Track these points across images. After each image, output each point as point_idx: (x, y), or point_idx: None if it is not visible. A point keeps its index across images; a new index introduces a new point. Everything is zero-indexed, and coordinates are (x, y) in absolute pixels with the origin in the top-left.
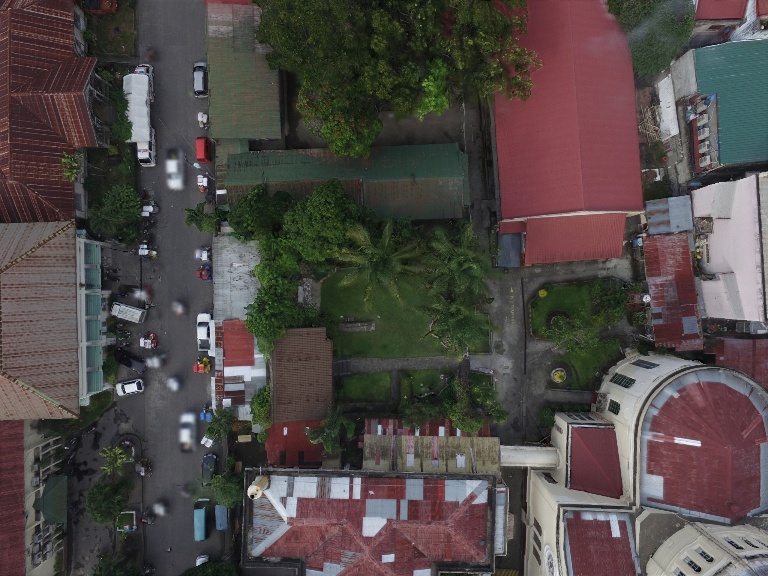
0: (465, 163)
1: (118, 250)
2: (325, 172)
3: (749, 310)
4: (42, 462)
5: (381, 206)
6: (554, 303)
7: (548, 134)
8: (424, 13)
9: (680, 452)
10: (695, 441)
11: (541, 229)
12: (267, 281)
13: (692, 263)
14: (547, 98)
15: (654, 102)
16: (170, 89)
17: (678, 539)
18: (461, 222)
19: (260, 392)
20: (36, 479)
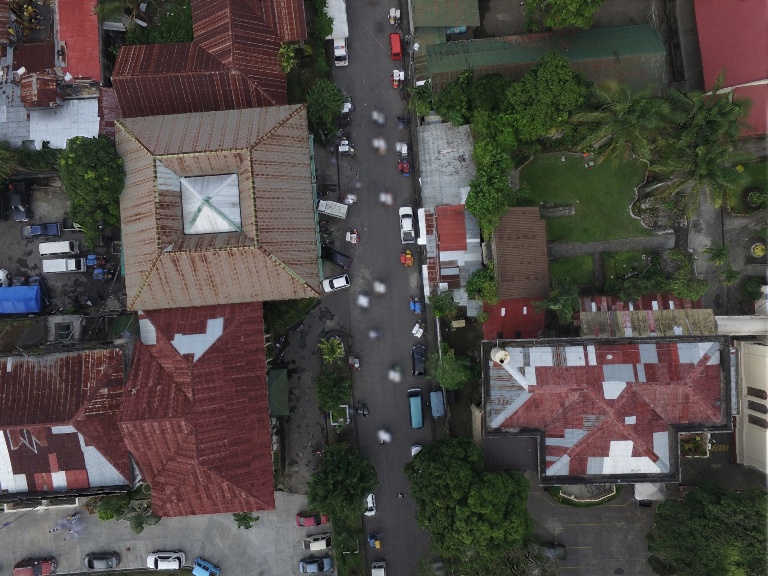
0: None
1: (315, 150)
2: (528, 55)
3: None
4: (266, 354)
5: None
6: (748, 180)
7: (754, 2)
8: None
9: None
10: None
11: (747, 99)
12: (489, 158)
13: None
14: None
15: None
16: None
17: None
18: (658, 102)
19: (479, 273)
20: None
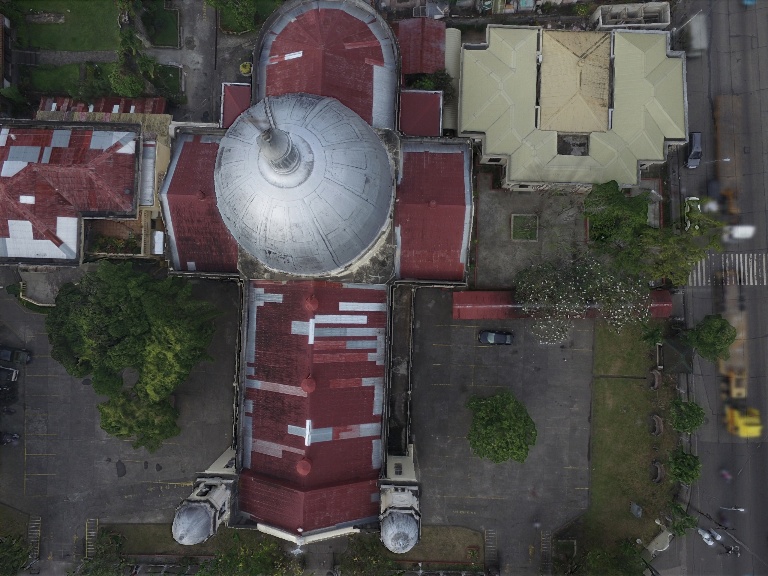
0: None
1: None
2: None
3: None
4: None
5: None
6: None
7: None
8: None
9: (288, 67)
10: (299, 52)
11: None
12: None
13: None
14: None
15: None
16: None
17: None
18: None
19: None
20: None
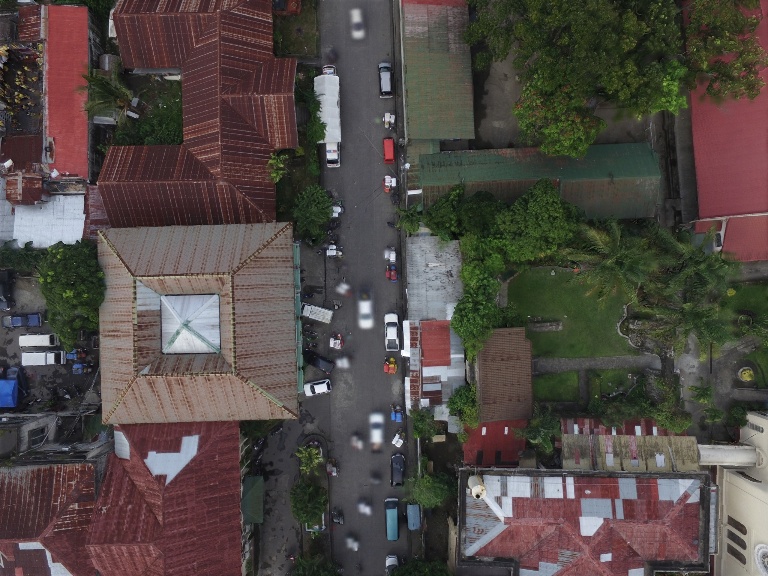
0: None
1: (303, 251)
2: (521, 172)
3: None
4: (242, 462)
5: None
6: (739, 302)
7: (752, 133)
8: (667, 12)
9: None
10: None
11: (741, 228)
12: (476, 281)
13: None
14: None
15: None
16: (353, 90)
17: None
18: (651, 221)
19: (461, 392)
20: None
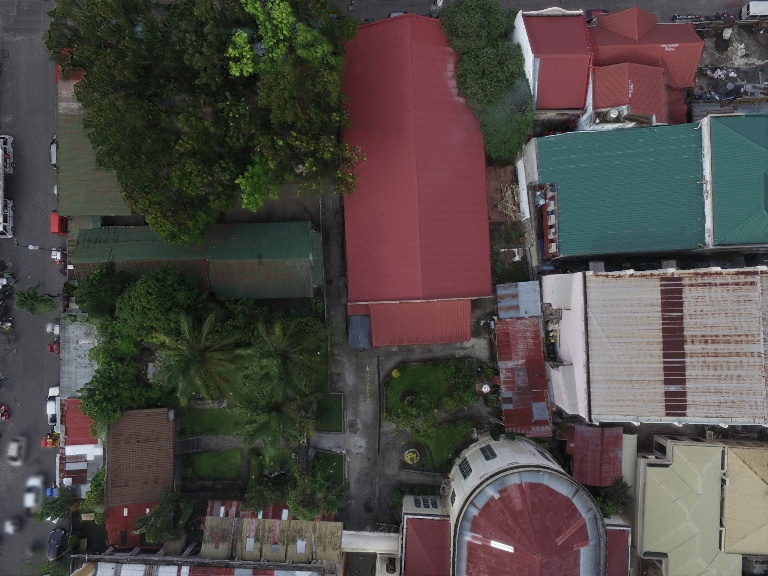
0: (317, 242)
1: None
2: (172, 251)
3: (581, 406)
4: None
5: (229, 285)
6: (410, 382)
7: (391, 219)
8: (236, 111)
9: (496, 556)
10: (509, 547)
11: (386, 313)
12: (101, 364)
13: (543, 348)
14: (390, 183)
15: (513, 182)
16: (30, 160)
17: None
18: (313, 301)
19: (99, 473)
20: None
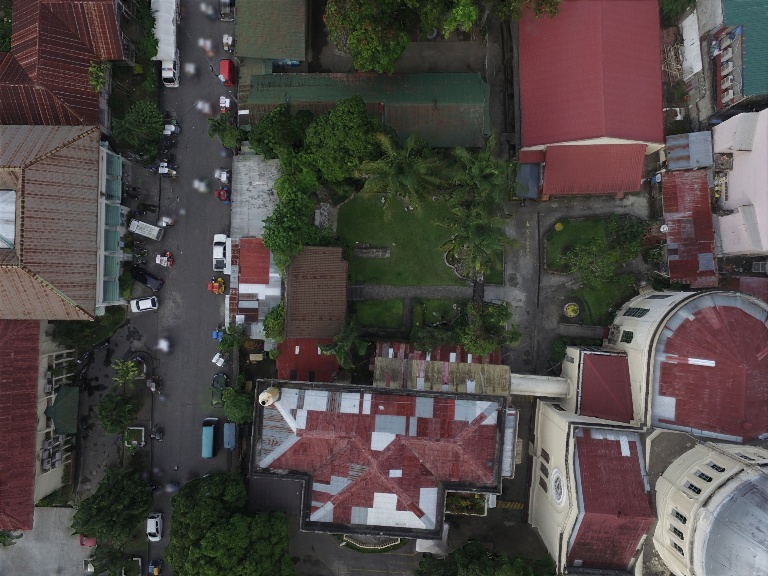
0: (486, 93)
1: (138, 169)
2: (347, 95)
3: (767, 240)
4: (55, 370)
5: (401, 131)
6: (569, 238)
7: (571, 62)
8: None
9: (694, 373)
10: (709, 361)
11: (560, 158)
12: (286, 195)
13: (710, 200)
14: (572, 26)
15: (678, 41)
16: (196, 12)
17: (689, 457)
18: (480, 152)
19: (274, 309)
20: (49, 386)
